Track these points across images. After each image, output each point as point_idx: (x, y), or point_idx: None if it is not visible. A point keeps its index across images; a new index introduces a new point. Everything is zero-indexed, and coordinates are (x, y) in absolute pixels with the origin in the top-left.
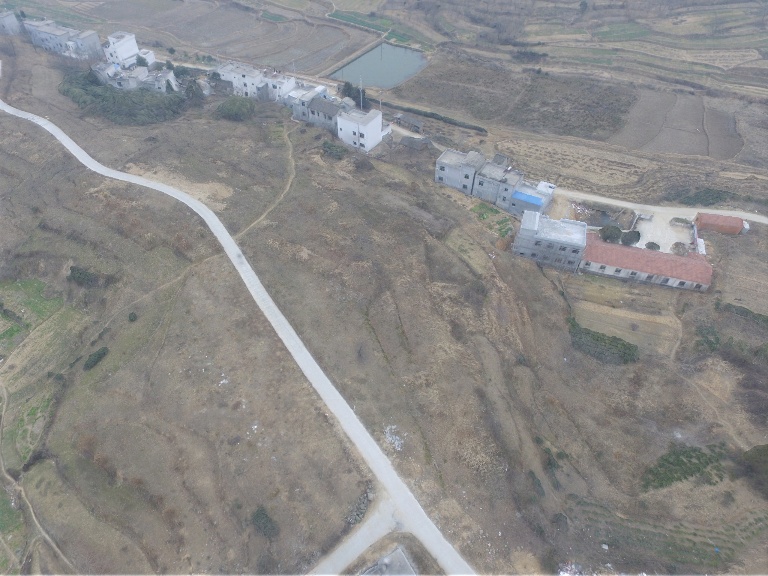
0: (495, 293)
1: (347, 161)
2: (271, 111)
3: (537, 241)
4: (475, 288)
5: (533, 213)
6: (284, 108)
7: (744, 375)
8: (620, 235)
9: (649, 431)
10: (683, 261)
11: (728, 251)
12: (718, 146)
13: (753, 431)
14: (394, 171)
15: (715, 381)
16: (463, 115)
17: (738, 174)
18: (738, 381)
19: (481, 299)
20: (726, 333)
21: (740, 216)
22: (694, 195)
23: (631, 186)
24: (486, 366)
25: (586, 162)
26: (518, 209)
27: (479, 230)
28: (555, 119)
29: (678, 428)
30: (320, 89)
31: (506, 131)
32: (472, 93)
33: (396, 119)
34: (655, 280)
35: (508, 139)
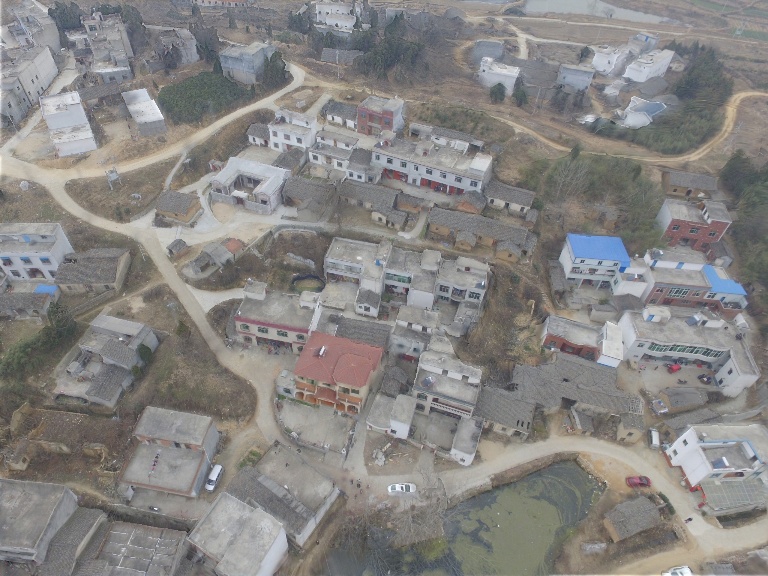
0: None
1: None
2: None
3: None
4: None
5: None
6: None
7: None
8: None
9: None
10: None
11: None
12: None
13: None
14: None
15: None
16: None
17: None
18: None
19: None
20: None
21: None
22: None
23: None
24: (109, 3)
25: None
26: None
27: None
28: None
29: (187, 23)
30: None
31: None
32: None
33: None
34: (226, 5)
35: None
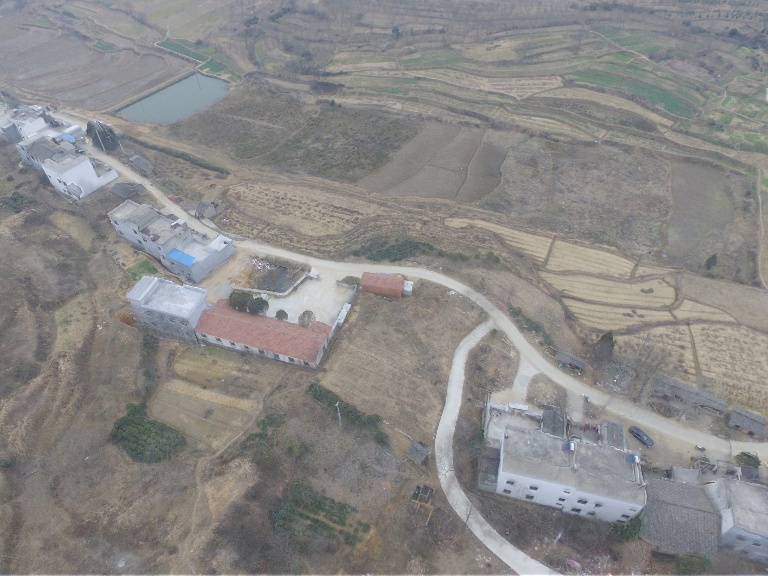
0: (38, 379)
1: (21, 215)
2: (1, 155)
3: (147, 311)
4: (12, 374)
5: (150, 279)
6: (18, 151)
7: (255, 483)
8: (247, 302)
9: (90, 559)
10: (294, 334)
11: (370, 319)
12: (471, 187)
13: (193, 563)
14: (71, 225)
15: (224, 489)
16: (222, 154)
17: (465, 221)
18: (246, 490)
19: (16, 387)
20: (289, 424)
21: (418, 274)
22: (386, 249)
23: (335, 237)
24: None
25: (310, 208)
26: (178, 268)
27: (110, 295)
28: (318, 157)
29: (130, 554)
30: (71, 129)
31: (252, 172)
32: (250, 128)
33: (130, 162)
34: (267, 355)
35: (244, 182)
